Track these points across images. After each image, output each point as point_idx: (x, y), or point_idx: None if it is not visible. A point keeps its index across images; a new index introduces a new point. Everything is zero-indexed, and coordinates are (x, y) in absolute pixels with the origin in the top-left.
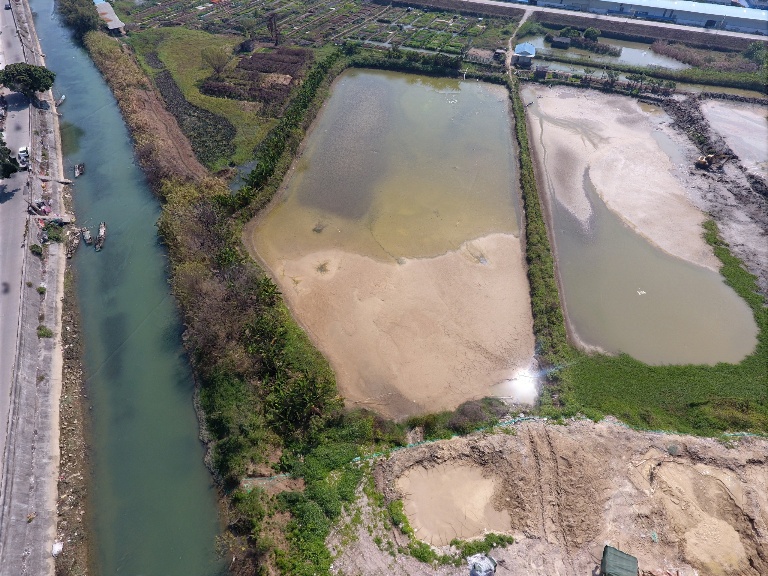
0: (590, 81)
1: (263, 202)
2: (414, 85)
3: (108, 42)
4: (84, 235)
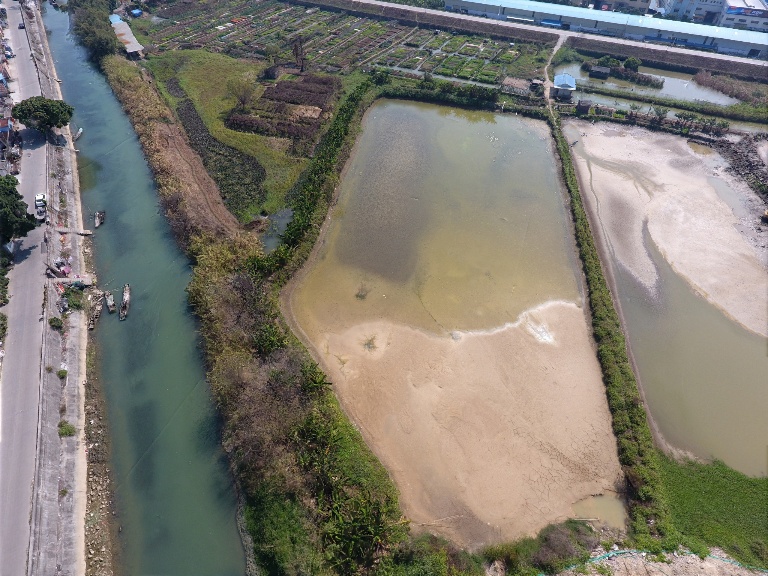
0: (636, 117)
1: (300, 261)
2: (450, 119)
3: (127, 68)
4: (107, 300)
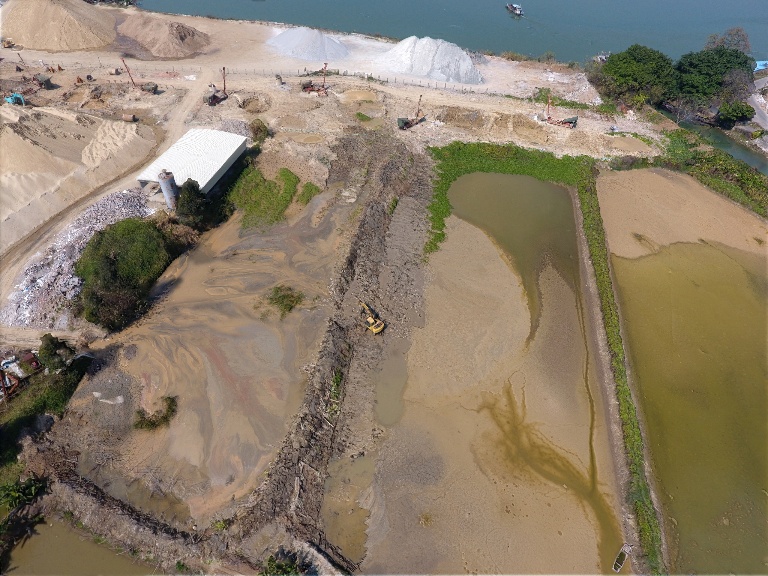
0: None
1: None
2: None
3: None
4: None
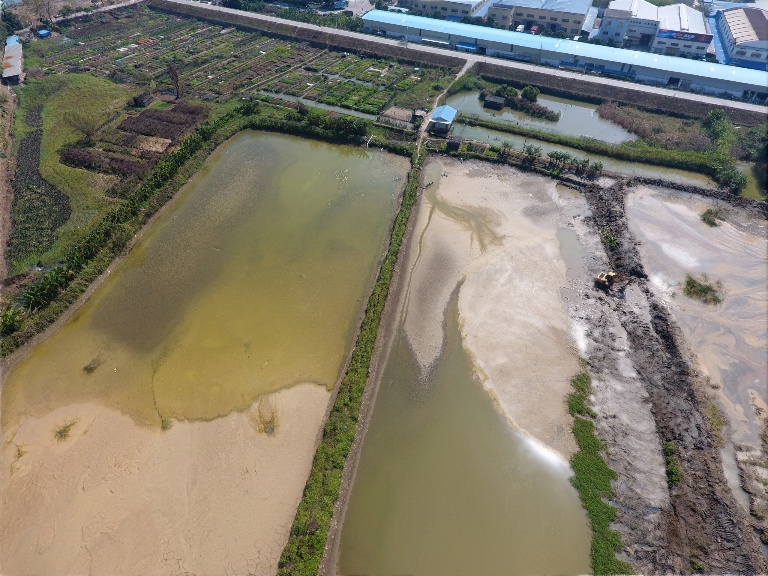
0: (508, 156)
1: (40, 325)
2: (307, 155)
3: None
4: None
